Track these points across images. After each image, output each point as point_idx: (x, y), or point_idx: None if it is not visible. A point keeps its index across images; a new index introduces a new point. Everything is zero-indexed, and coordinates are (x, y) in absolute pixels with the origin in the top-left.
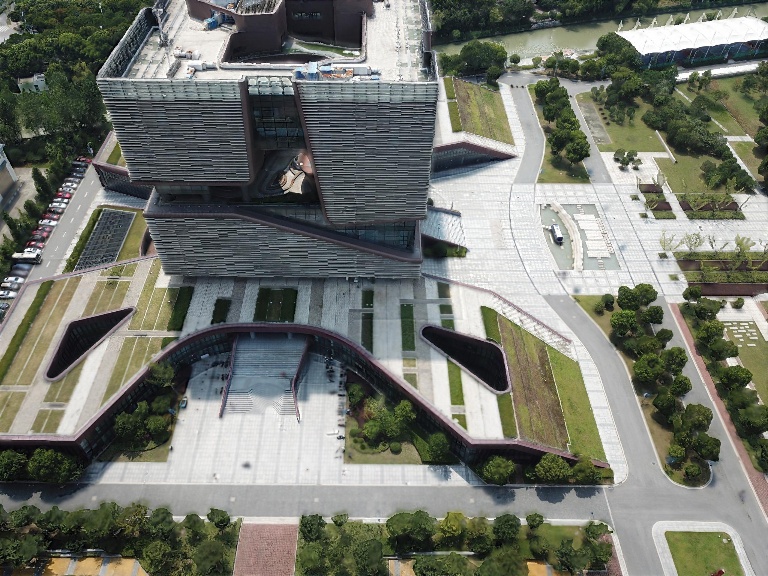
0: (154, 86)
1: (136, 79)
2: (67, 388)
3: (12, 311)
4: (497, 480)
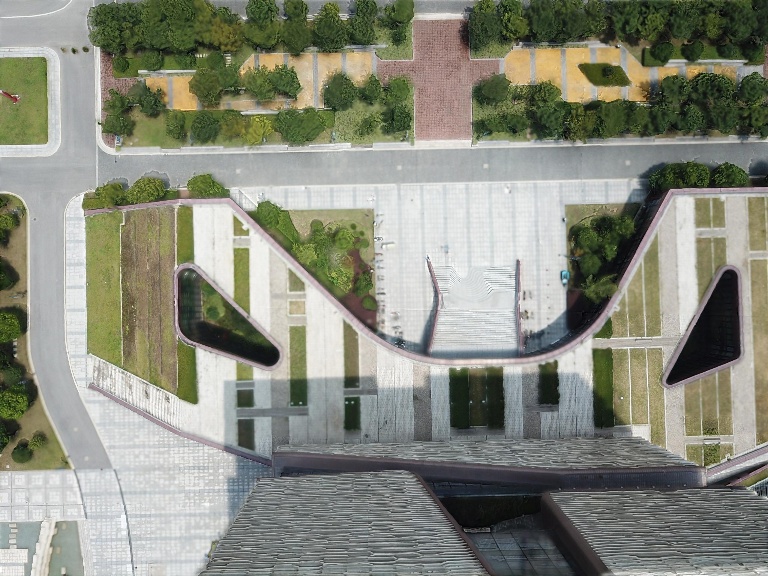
0: None
1: None
2: (705, 257)
3: None
4: (208, 174)
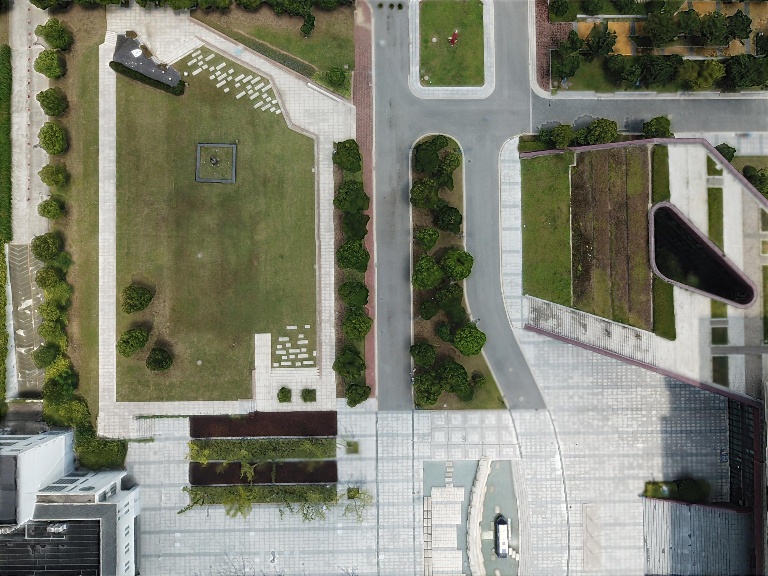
0: None
1: None
2: None
3: None
4: None
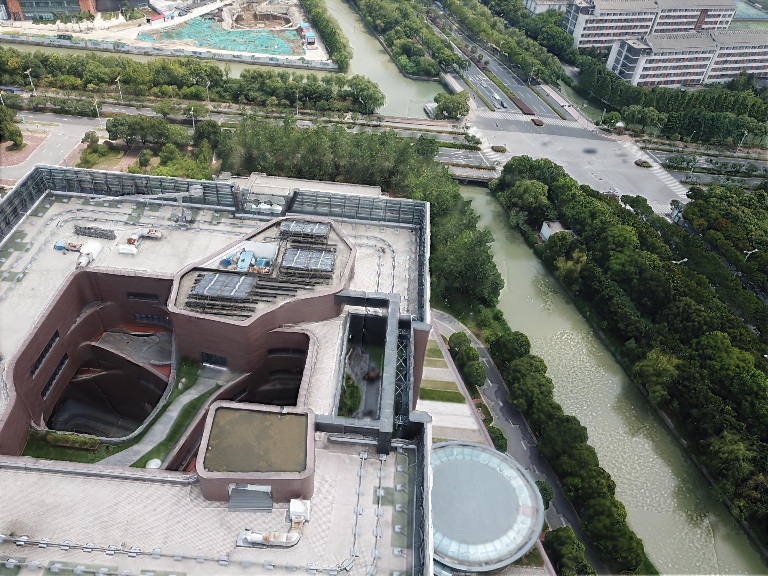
0: (5, 208)
1: (12, 190)
2: None
3: None
4: None
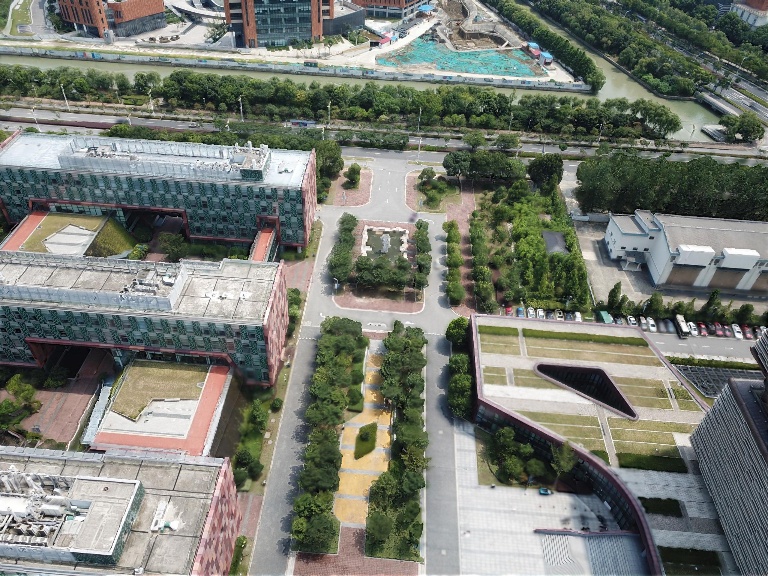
0: None
1: None
2: (529, 382)
3: (602, 325)
4: None
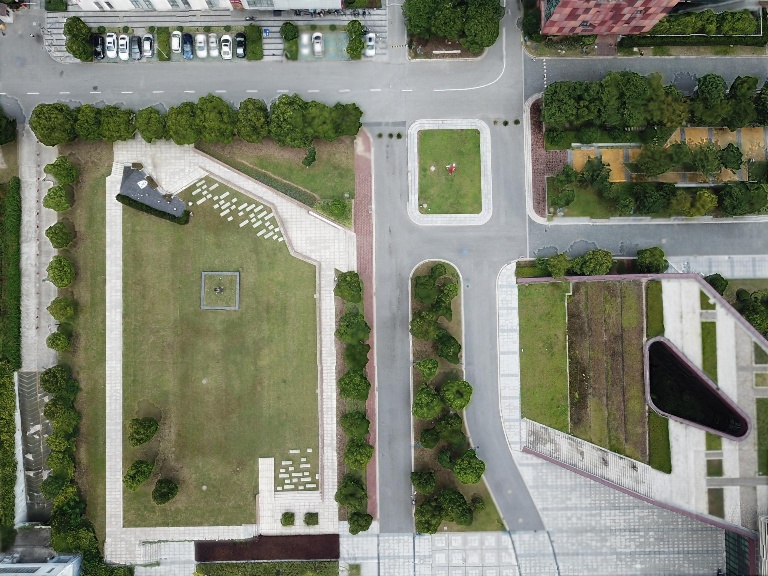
0: None
1: None
2: None
3: None
4: None
